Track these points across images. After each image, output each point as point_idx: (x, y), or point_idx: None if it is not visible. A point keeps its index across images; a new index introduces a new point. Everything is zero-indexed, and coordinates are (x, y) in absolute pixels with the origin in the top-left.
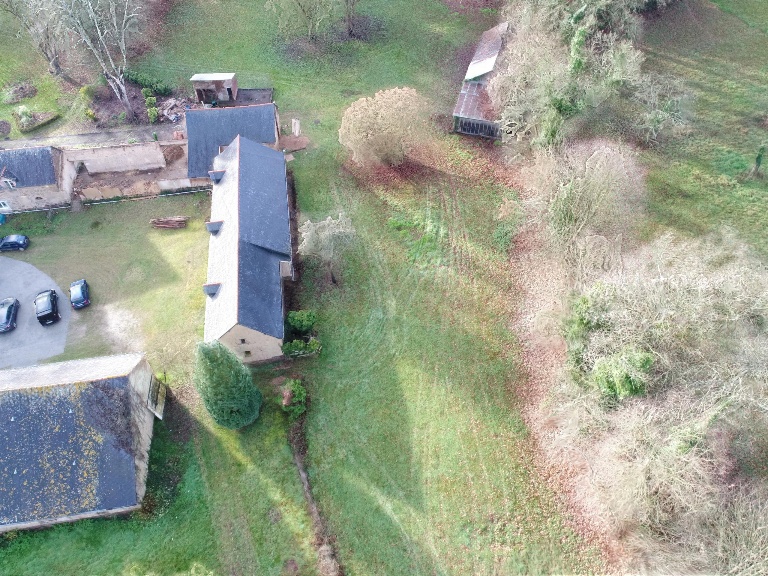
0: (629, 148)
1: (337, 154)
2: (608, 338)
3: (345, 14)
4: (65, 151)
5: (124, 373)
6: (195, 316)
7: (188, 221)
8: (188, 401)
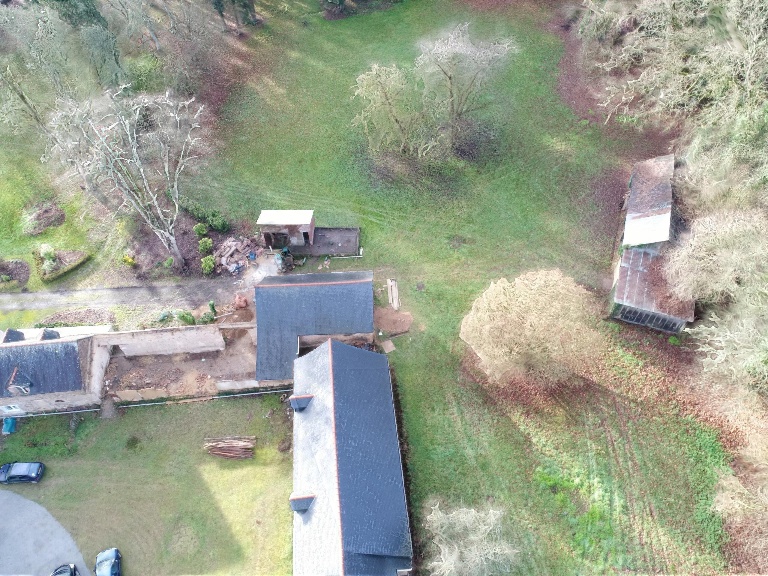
0: None
1: (452, 344)
2: None
3: None
4: (96, 335)
5: None
6: None
7: (256, 446)
8: None
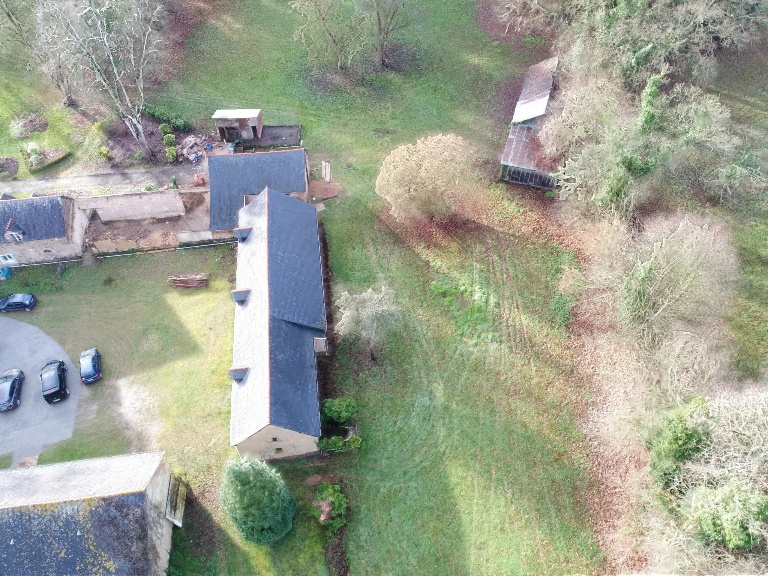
0: (697, 204)
1: (372, 204)
2: (709, 465)
3: (378, 43)
4: (76, 199)
5: (140, 487)
6: (218, 396)
7: (210, 279)
8: (211, 503)
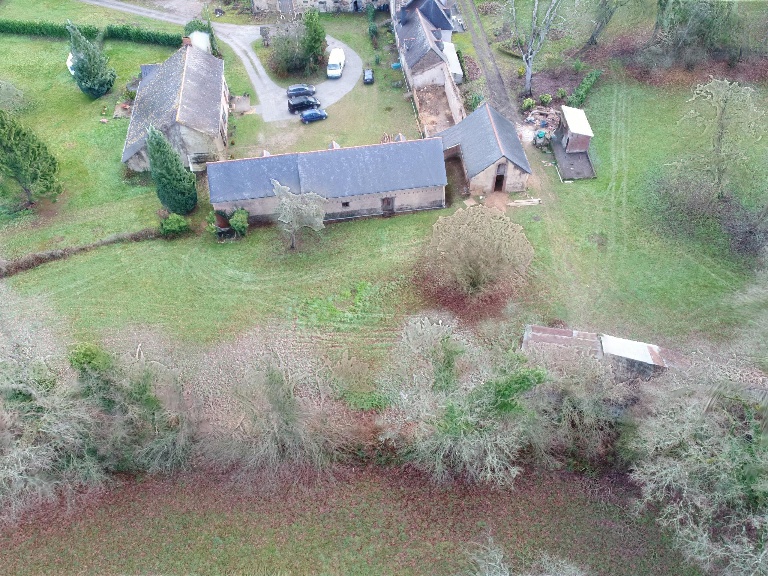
0: None
1: None
2: None
3: (764, 210)
4: (445, 63)
5: (180, 120)
6: None
7: None
8: (203, 182)
